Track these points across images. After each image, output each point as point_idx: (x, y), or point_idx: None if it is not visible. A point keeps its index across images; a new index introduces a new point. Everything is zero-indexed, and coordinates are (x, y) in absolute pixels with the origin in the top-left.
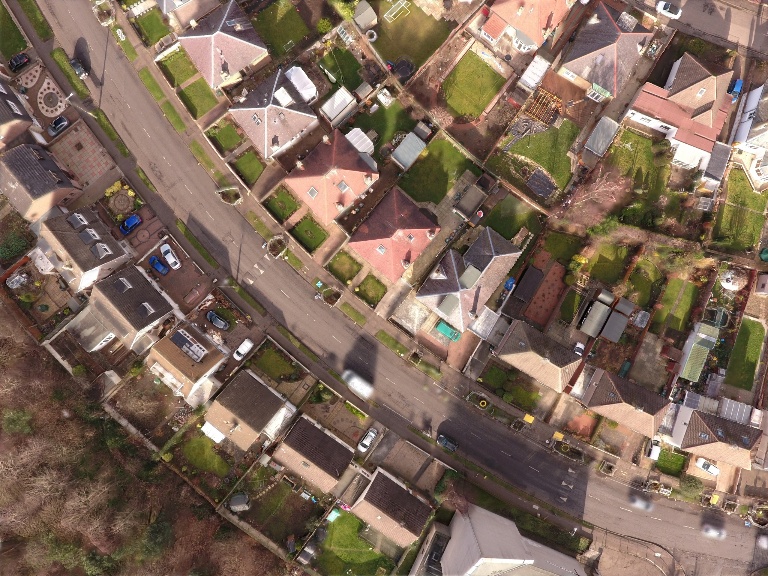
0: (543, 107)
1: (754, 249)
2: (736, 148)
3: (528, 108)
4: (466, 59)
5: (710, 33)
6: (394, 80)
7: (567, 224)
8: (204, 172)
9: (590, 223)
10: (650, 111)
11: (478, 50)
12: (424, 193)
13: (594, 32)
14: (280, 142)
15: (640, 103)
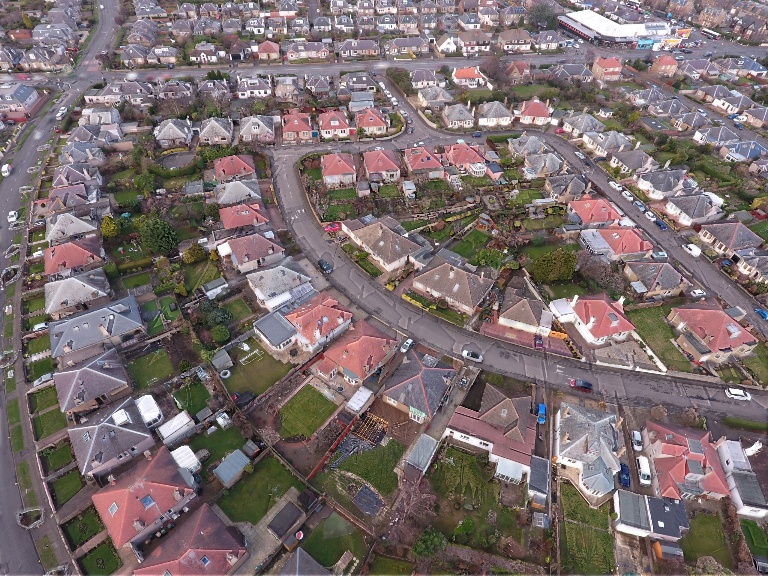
0: (370, 428)
1: (613, 575)
2: (558, 463)
3: (356, 429)
4: (304, 390)
5: (510, 371)
6: (233, 405)
7: (396, 546)
8: (17, 492)
9: (414, 542)
10: (465, 429)
11: (315, 384)
12: (243, 512)
13: (406, 368)
14: (104, 458)
15: (454, 422)
